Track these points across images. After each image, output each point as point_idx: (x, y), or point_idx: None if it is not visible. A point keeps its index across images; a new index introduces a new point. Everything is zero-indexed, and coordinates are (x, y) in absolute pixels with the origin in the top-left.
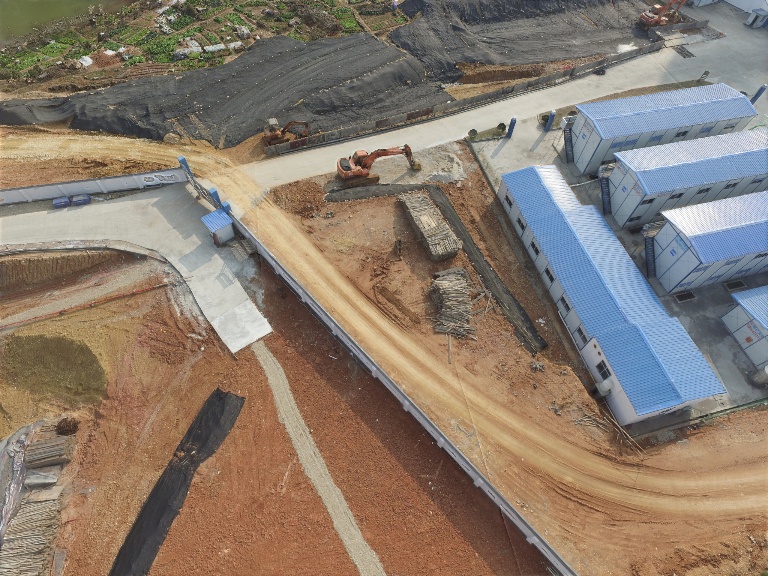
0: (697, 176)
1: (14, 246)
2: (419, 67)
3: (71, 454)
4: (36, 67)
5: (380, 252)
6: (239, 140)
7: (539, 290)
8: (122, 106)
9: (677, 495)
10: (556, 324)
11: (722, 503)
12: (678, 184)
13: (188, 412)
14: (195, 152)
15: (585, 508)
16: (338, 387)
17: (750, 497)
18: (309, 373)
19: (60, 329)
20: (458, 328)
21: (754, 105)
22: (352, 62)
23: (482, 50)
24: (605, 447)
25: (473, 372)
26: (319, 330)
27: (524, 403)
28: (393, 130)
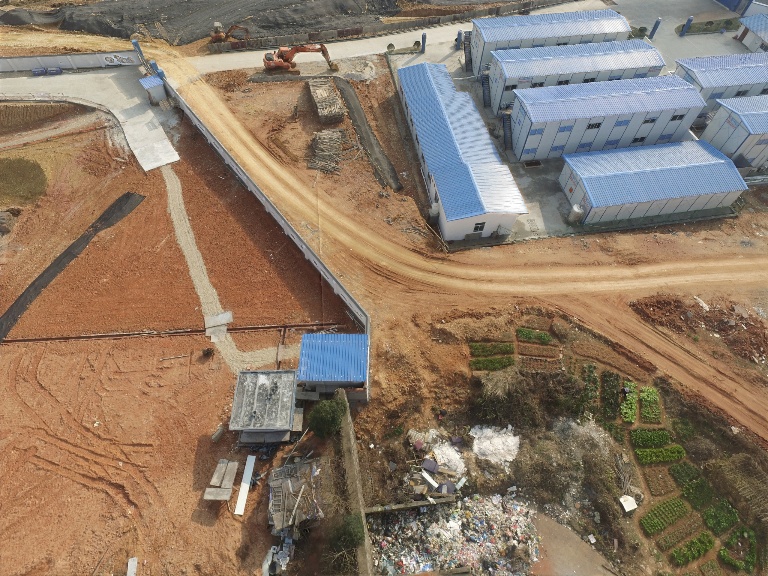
0: (554, 68)
1: None
2: (361, 1)
3: (11, 227)
4: None
5: (281, 116)
6: (191, 41)
7: (410, 154)
8: (102, 14)
9: (467, 279)
10: (416, 176)
11: (503, 286)
12: (536, 72)
13: (103, 206)
14: (153, 47)
15: (390, 281)
16: (219, 195)
17: (528, 285)
18: (200, 186)
19: (21, 154)
20: (327, 165)
21: (653, 39)
22: None
23: None
24: (420, 246)
25: (330, 194)
26: (216, 161)
27: (365, 216)
28: (324, 43)
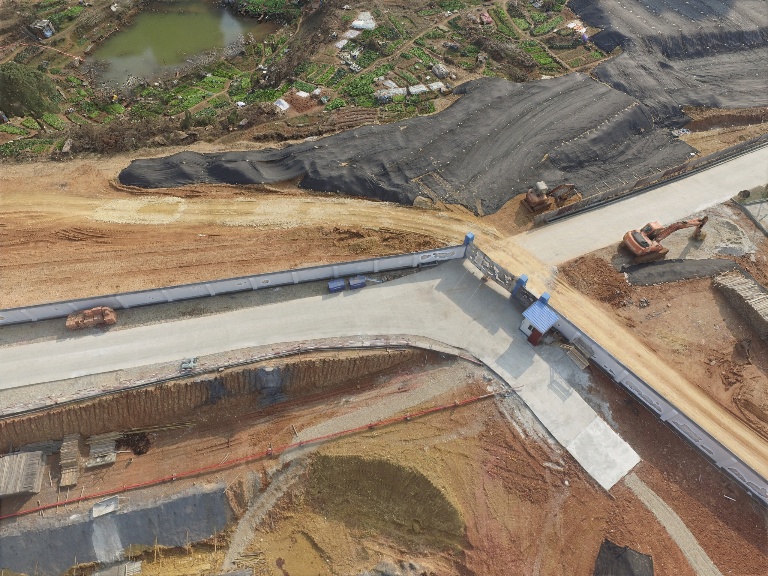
0: None
1: (301, 342)
2: (647, 112)
3: None
4: (234, 112)
5: (722, 352)
6: (498, 205)
7: None
8: (356, 163)
9: None
10: None
11: None
12: None
13: (578, 571)
14: (454, 220)
15: None
16: (755, 541)
17: None
18: (711, 520)
19: (378, 449)
20: None
21: None
22: (581, 108)
23: (706, 92)
24: None
25: None
26: (696, 459)
27: None
28: (650, 190)
